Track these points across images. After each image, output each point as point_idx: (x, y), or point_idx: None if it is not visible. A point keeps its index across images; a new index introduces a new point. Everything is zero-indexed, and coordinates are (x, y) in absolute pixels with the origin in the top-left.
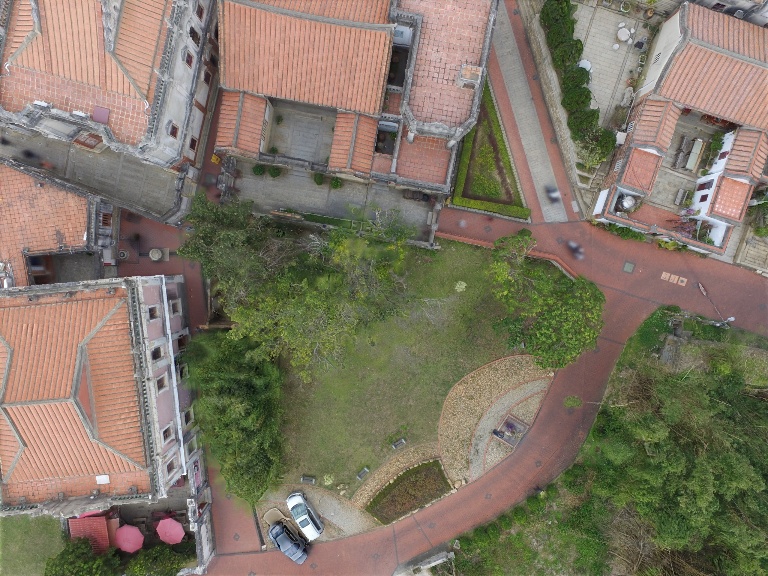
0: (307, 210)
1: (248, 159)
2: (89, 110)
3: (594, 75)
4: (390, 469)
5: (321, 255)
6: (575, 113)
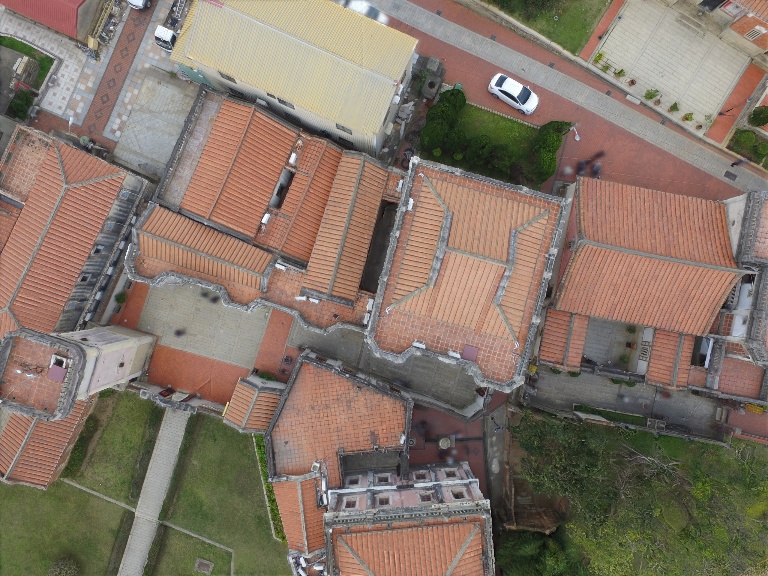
0: (598, 405)
1: None
2: (458, 348)
3: None
4: None
5: None
6: None
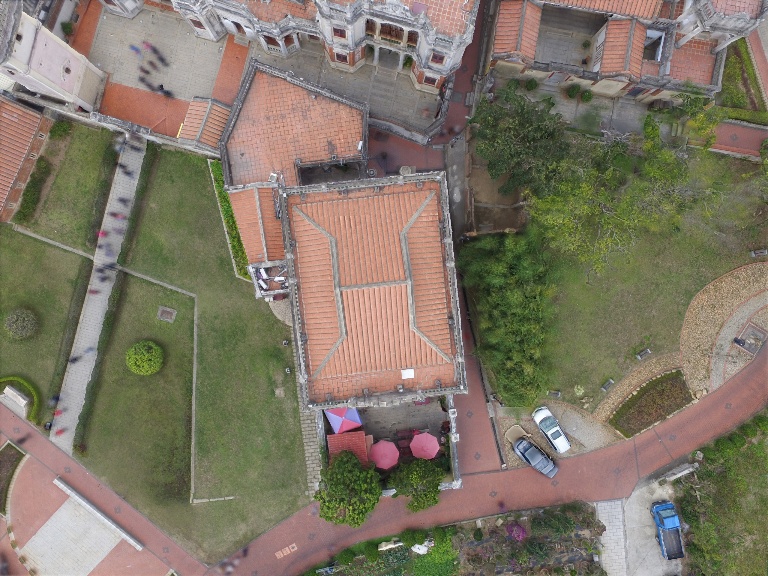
0: None
1: (509, 72)
2: (408, 6)
3: None
4: (632, 381)
5: (607, 152)
6: None
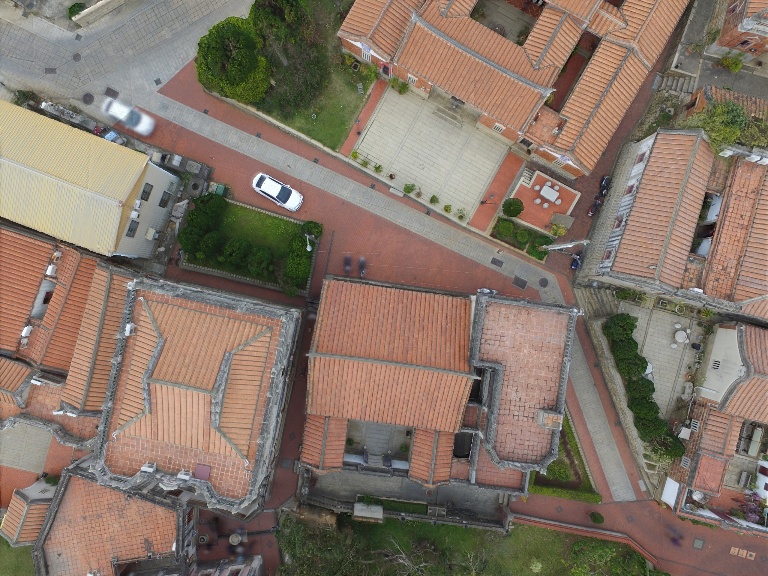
0: (382, 494)
1: None
2: (191, 468)
3: (654, 371)
4: None
5: (409, 573)
6: (643, 420)
